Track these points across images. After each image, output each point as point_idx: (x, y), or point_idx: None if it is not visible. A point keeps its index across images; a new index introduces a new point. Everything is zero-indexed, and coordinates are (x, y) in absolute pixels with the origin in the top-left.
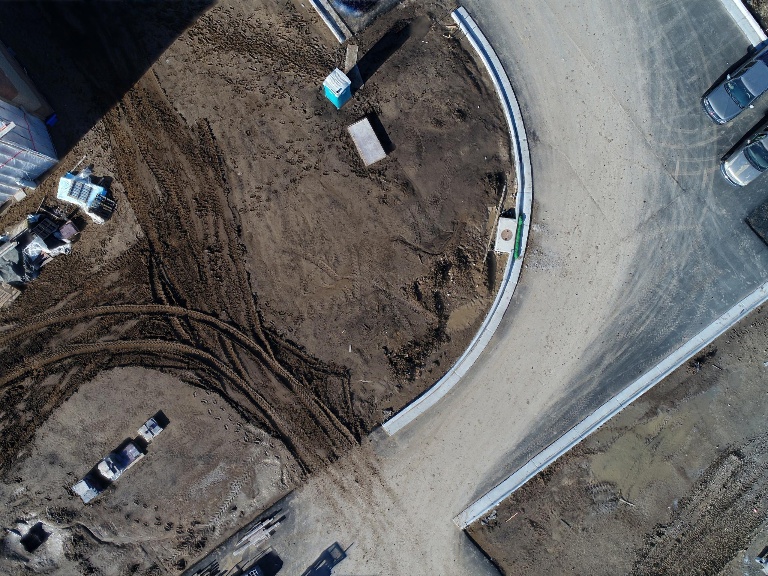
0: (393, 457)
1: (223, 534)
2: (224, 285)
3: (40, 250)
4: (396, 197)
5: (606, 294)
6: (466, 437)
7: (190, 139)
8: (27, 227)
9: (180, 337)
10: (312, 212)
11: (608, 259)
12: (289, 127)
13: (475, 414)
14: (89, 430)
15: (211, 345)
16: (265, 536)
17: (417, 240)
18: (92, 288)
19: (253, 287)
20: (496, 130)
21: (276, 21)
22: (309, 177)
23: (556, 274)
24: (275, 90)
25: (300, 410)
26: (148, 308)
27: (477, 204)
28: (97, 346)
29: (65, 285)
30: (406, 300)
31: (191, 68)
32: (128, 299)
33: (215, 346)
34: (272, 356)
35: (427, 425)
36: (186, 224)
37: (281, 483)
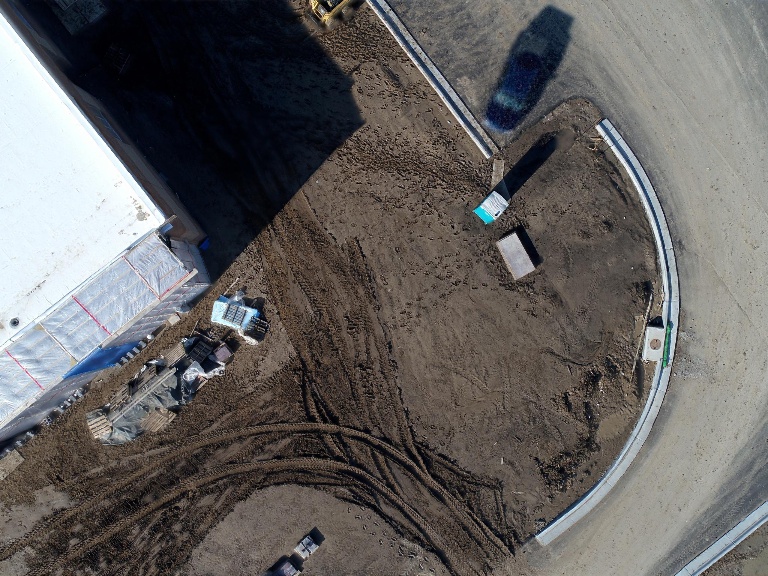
0: (547, 568)
1: None
2: (376, 401)
3: (197, 374)
4: (545, 309)
5: (755, 400)
6: (619, 546)
7: (340, 258)
8: (185, 353)
9: (333, 454)
10: (462, 326)
11: (756, 365)
12: (437, 243)
13: (627, 523)
14: (245, 549)
15: (364, 461)
16: None
17: (566, 351)
18: (246, 408)
19: (405, 402)
20: (642, 240)
21: (423, 139)
22: (458, 292)
23: (704, 381)
24: (423, 207)
25: (454, 523)
26: (301, 426)
27: (624, 314)
28: (251, 465)
29: (219, 406)
30: (556, 411)
31: (340, 188)
32: (281, 418)
33: (368, 462)
34: (425, 471)
35: (580, 535)
36: (338, 342)
37: None
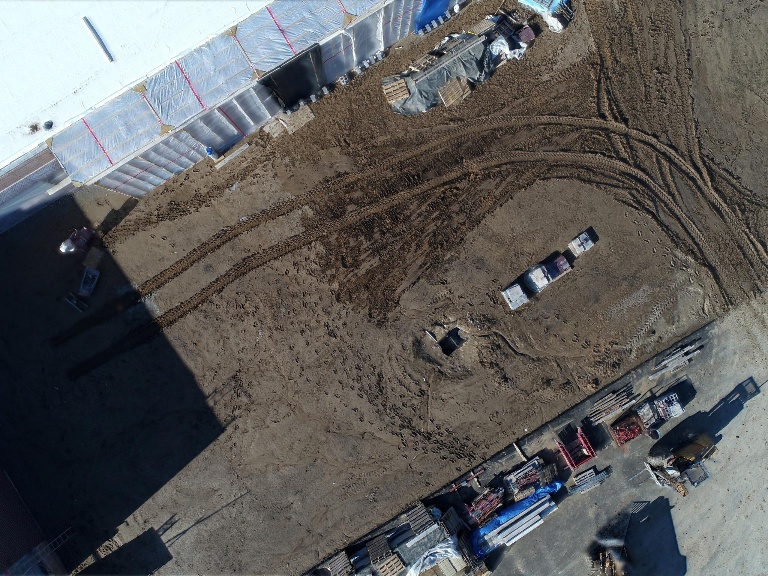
0: None
1: (639, 358)
2: (667, 107)
3: (501, 49)
4: None
5: None
6: None
7: None
8: None
9: (618, 155)
10: (762, 43)
11: None
12: None
13: None
14: (518, 239)
15: (648, 166)
16: (683, 363)
17: None
18: (538, 97)
19: (695, 113)
20: None
21: None
22: (763, 8)
23: None
24: None
25: (729, 241)
26: (590, 123)
27: None
28: (536, 155)
29: (513, 90)
30: None
31: None
32: (572, 111)
33: (652, 168)
34: (708, 183)
35: None
36: (638, 42)
37: (702, 312)
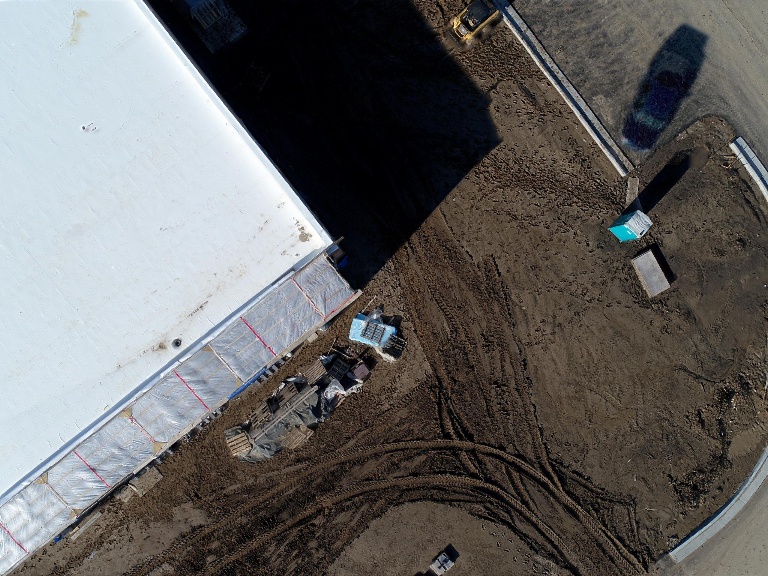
0: None
1: None
2: (511, 418)
3: (336, 392)
4: (679, 327)
5: None
6: (751, 562)
7: (476, 275)
8: (326, 371)
9: (468, 471)
10: (596, 344)
11: None
12: (572, 261)
13: (760, 539)
14: (380, 565)
15: (499, 478)
16: None
17: (699, 368)
18: (381, 425)
19: (539, 419)
20: None
21: (560, 157)
22: (592, 309)
23: None
24: (559, 225)
25: (587, 540)
26: (436, 443)
27: (757, 331)
28: (387, 482)
29: (356, 423)
30: (689, 428)
31: (477, 206)
32: (417, 435)
33: (503, 479)
34: (559, 487)
35: (713, 552)
36: (473, 359)
37: None
